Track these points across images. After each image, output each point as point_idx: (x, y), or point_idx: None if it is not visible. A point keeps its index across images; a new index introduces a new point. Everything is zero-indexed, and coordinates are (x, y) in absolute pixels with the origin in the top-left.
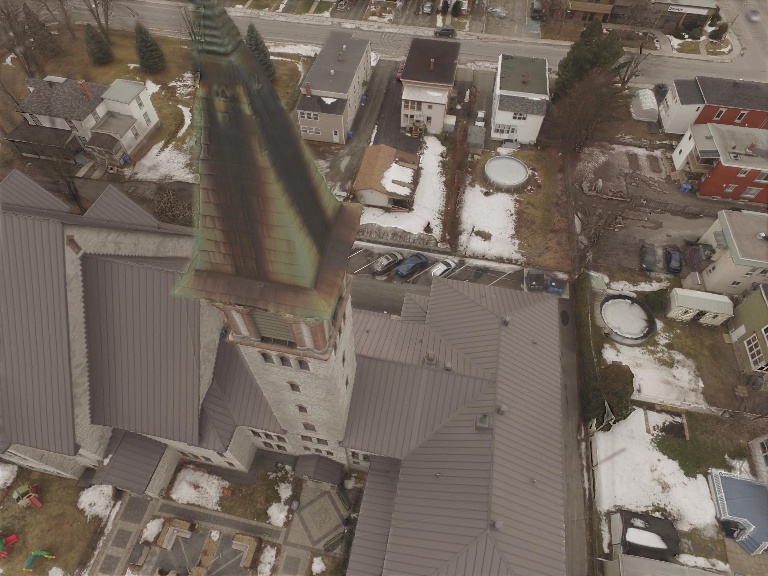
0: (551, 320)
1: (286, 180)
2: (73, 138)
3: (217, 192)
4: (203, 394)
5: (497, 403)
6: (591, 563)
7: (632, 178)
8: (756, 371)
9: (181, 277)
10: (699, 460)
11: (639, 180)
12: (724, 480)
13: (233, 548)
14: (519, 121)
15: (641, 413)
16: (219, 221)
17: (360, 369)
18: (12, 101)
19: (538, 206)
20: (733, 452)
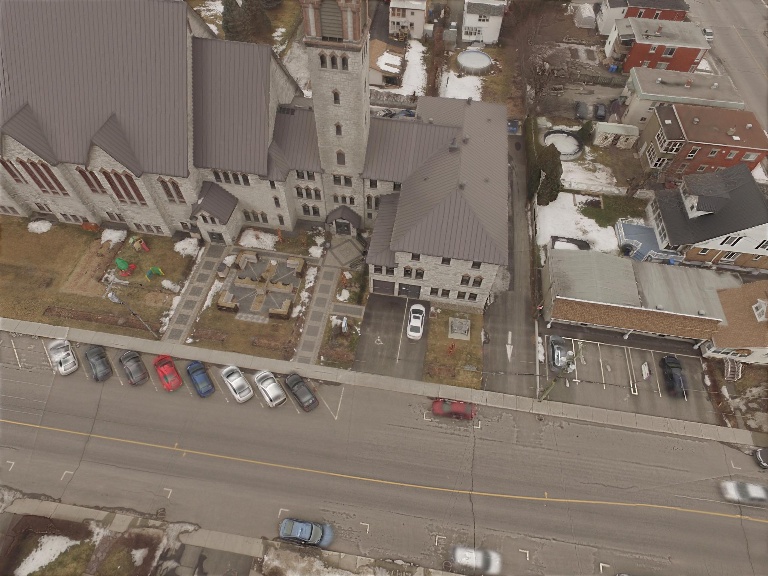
0: (502, 115)
1: None
2: None
3: None
4: (268, 144)
5: (463, 137)
6: (532, 270)
7: (573, 64)
8: (653, 168)
9: (258, 47)
10: (610, 219)
11: (578, 65)
12: (625, 226)
13: (287, 267)
14: (483, 23)
15: (571, 195)
16: None
17: (372, 126)
18: None
19: (499, 83)
20: (634, 214)
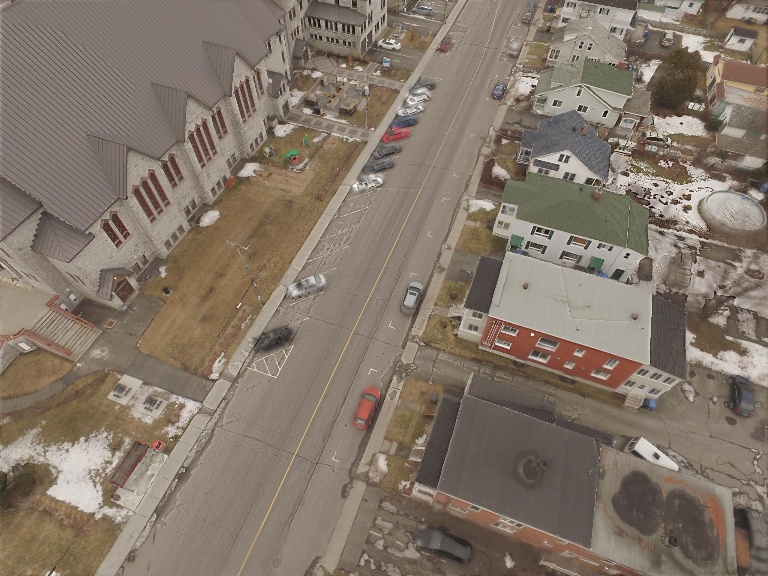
0: None
1: None
2: None
3: None
4: None
5: None
6: None
7: None
8: None
9: None
10: None
11: None
12: None
13: None
14: None
15: None
16: None
17: None
18: None
19: None
20: None
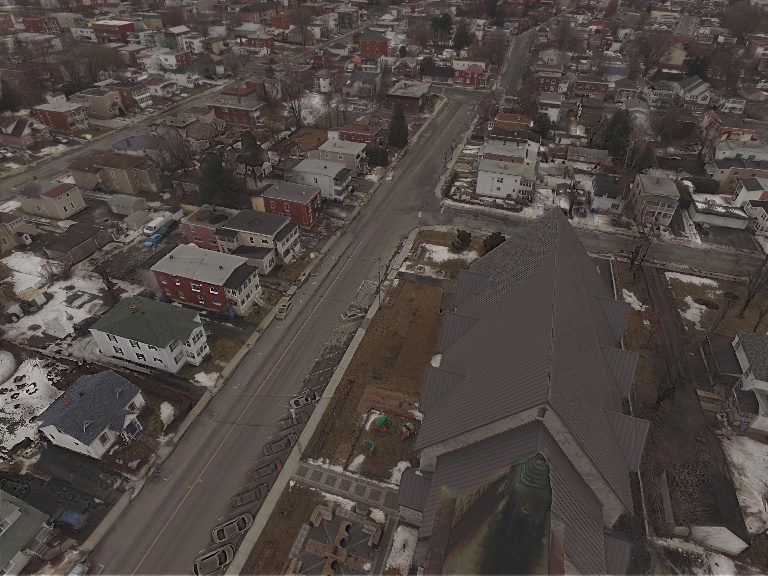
0: None
1: (488, 553)
2: (736, 377)
3: (478, 498)
4: None
5: None
6: None
7: None
8: None
9: None
10: None
11: None
12: None
13: None
14: None
15: None
16: (469, 505)
17: None
18: (763, 322)
19: None
20: None
